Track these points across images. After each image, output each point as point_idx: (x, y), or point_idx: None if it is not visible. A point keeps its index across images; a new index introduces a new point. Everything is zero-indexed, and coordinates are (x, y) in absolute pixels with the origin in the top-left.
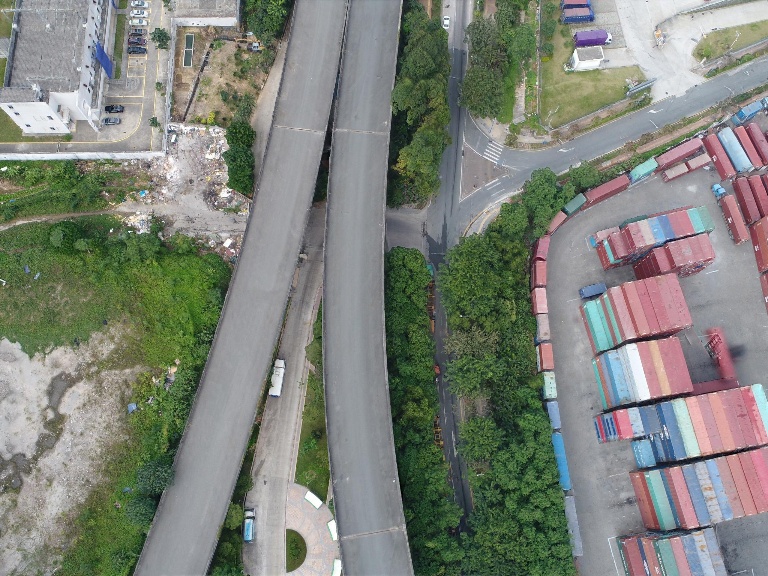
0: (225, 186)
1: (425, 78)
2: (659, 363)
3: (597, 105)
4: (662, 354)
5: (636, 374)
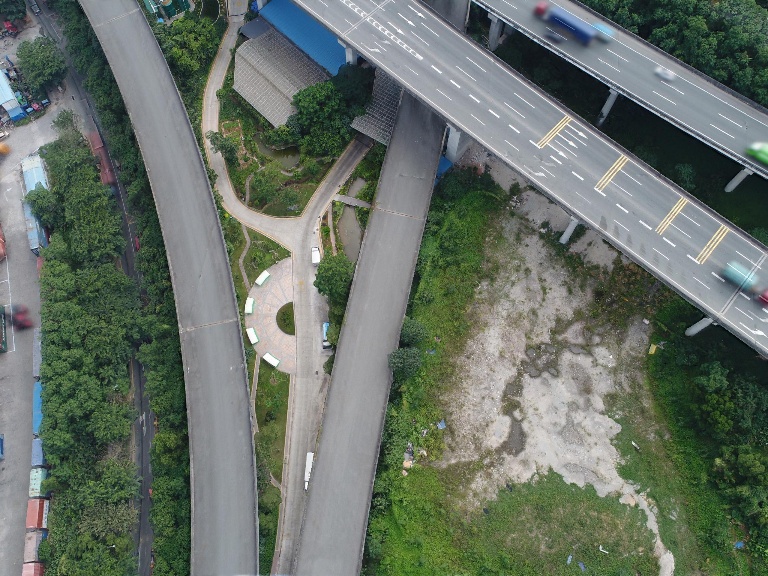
0: None
1: None
2: None
3: None
4: None
5: None
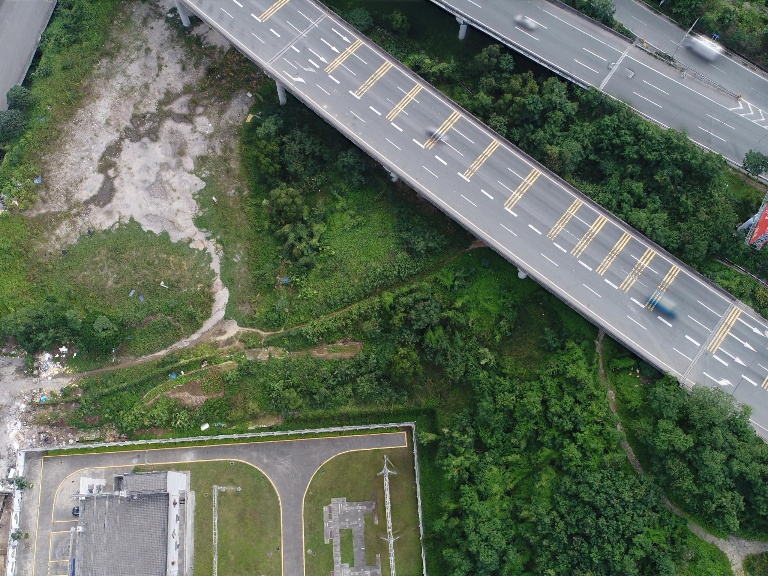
0: None
1: None
2: None
3: None
4: None
5: None
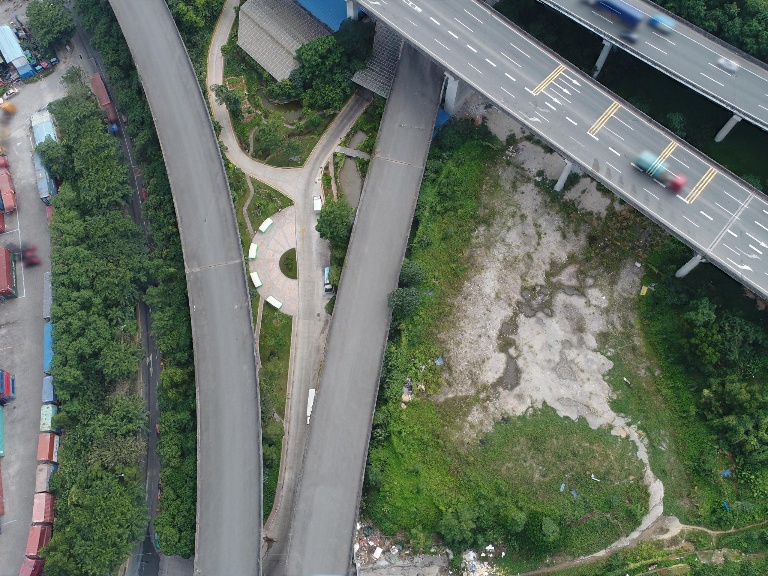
0: None
1: None
2: None
3: None
4: None
5: None
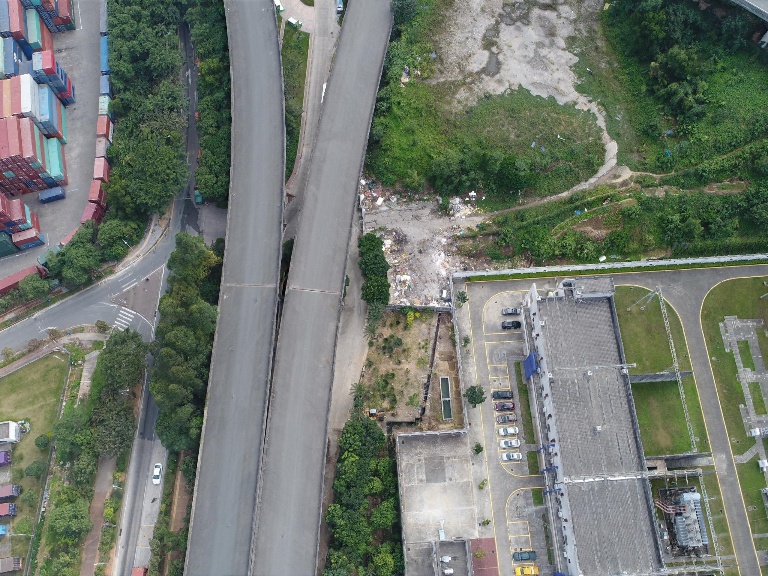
0: (388, 250)
1: (178, 326)
2: (7, 101)
3: (4, 383)
4: (2, 108)
5: (29, 91)
